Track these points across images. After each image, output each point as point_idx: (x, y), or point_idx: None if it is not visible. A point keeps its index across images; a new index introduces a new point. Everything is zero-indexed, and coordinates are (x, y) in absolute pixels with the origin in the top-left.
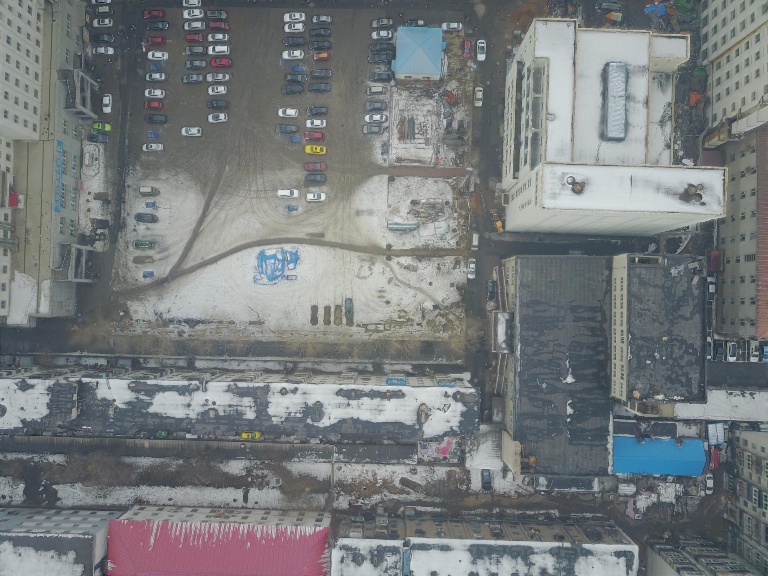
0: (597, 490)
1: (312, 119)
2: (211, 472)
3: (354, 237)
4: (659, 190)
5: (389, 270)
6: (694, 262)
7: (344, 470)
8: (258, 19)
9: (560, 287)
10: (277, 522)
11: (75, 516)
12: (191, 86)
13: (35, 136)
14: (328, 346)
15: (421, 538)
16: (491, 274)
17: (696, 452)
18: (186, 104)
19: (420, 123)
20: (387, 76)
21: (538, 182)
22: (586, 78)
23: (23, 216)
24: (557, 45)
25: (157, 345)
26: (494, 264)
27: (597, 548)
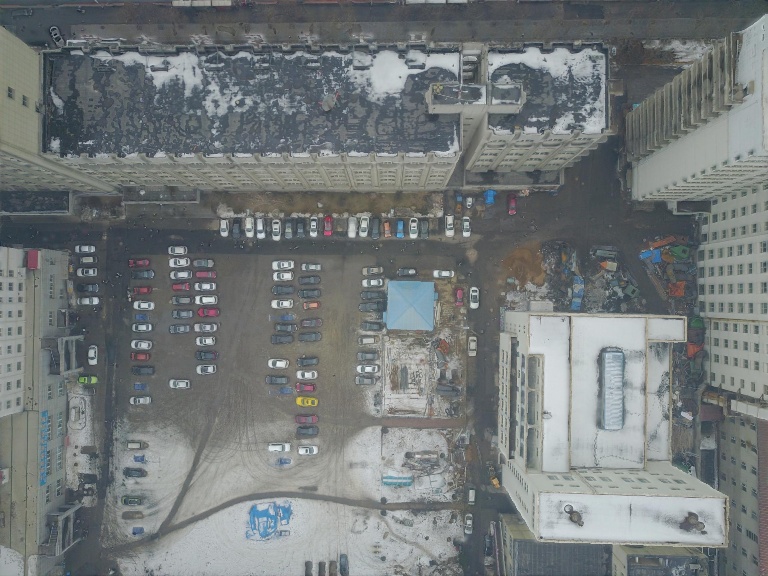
0: None
1: (303, 371)
2: None
3: (348, 490)
4: (659, 519)
5: (384, 524)
6: (696, 564)
7: None
8: (246, 266)
9: (559, 572)
10: None
11: None
12: (179, 336)
13: (19, 409)
14: None
15: None
16: (488, 528)
17: None
18: (174, 354)
19: (413, 373)
20: (379, 327)
21: (535, 507)
22: (582, 364)
23: (8, 489)
24: (552, 340)
25: None
26: (491, 518)
27: None
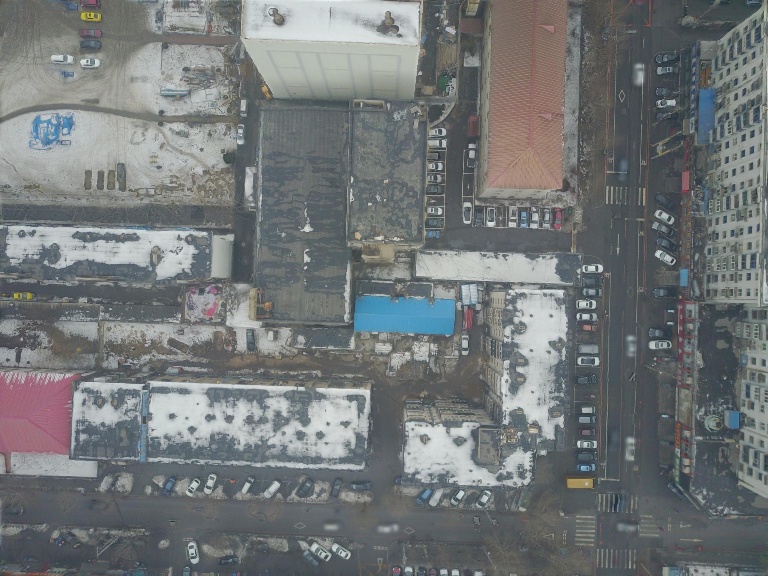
0: (353, 348)
1: None
2: None
3: (128, 103)
4: (357, 22)
5: (161, 136)
6: (415, 106)
7: (114, 331)
8: None
9: (300, 138)
10: None
11: None
12: None
13: None
14: (101, 210)
15: (161, 382)
16: None
17: (447, 310)
18: None
19: None
20: None
21: None
22: None
23: None
24: None
25: None
26: None
27: (330, 392)
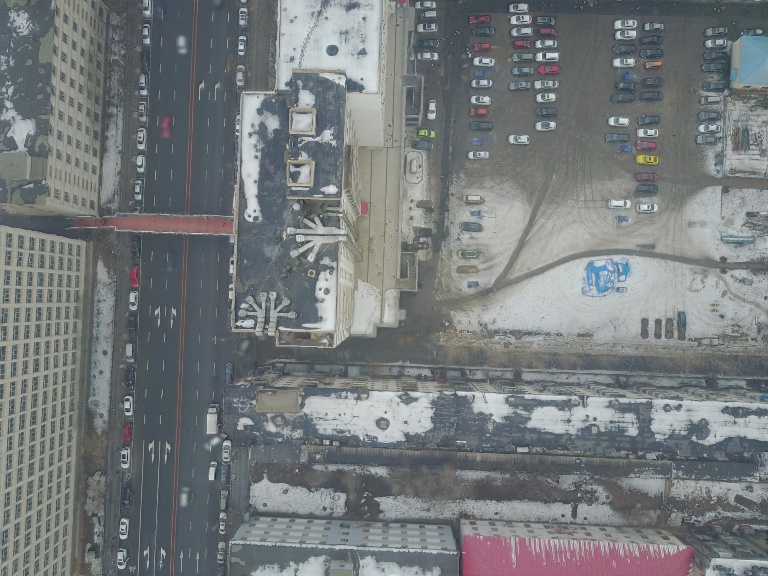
0: None
1: (645, 128)
2: (538, 486)
3: (686, 249)
4: None
5: (722, 283)
6: None
7: (677, 487)
8: (586, 26)
9: None
10: (627, 540)
11: (410, 530)
12: (517, 93)
13: None
14: (659, 360)
15: None
16: None
17: None
18: (512, 111)
19: (755, 134)
20: (724, 86)
21: None
22: None
23: (366, 224)
24: None
25: (482, 356)
26: None
27: None
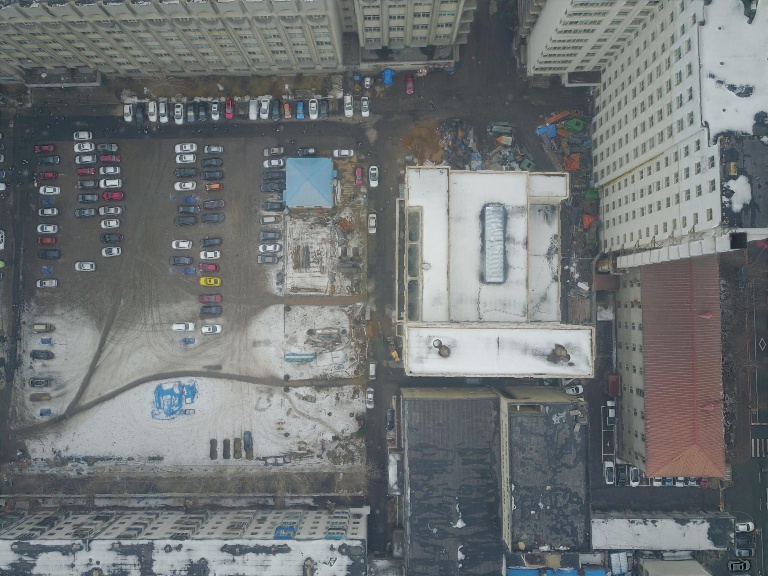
0: None
1: (206, 251)
2: None
3: (252, 368)
4: (526, 351)
5: (288, 401)
6: (575, 410)
7: None
8: (150, 150)
9: (448, 430)
10: None
11: None
12: (84, 220)
13: None
14: (228, 480)
15: None
16: (390, 403)
17: None
18: (80, 238)
19: (315, 251)
20: (279, 206)
21: None
22: (465, 220)
23: None
24: (431, 193)
25: (56, 484)
26: (393, 393)
27: None
